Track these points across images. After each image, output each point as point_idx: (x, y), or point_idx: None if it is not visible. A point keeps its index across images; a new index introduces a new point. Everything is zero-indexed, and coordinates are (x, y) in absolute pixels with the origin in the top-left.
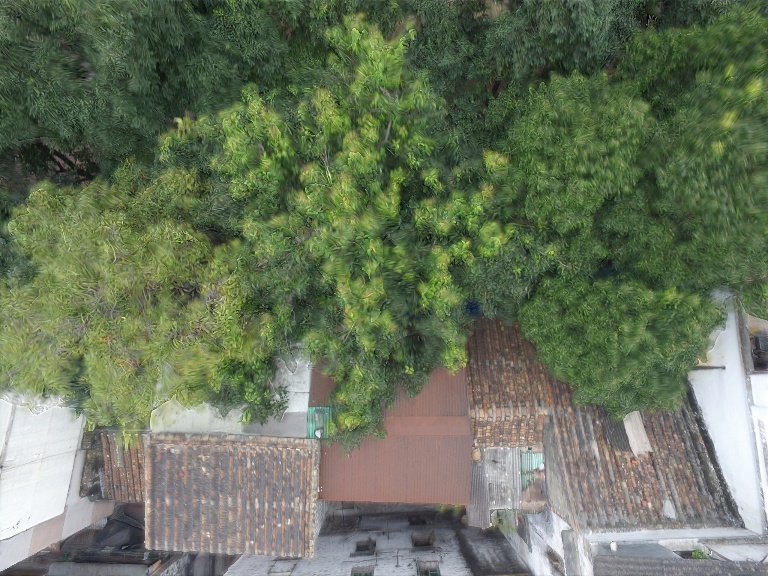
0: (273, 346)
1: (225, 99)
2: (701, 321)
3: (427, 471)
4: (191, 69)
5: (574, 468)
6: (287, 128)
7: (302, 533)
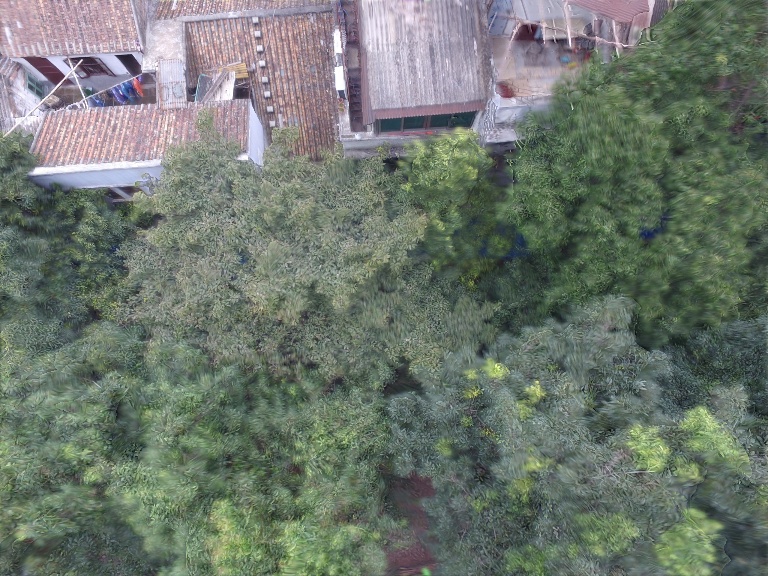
0: None
1: None
2: None
3: None
4: None
5: None
6: None
7: None
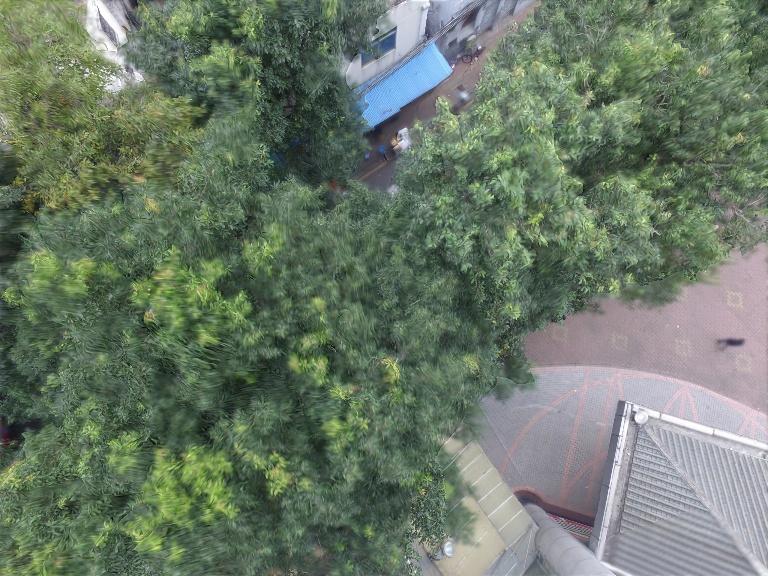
0: None
1: None
2: None
3: None
4: None
5: None
6: None
7: None
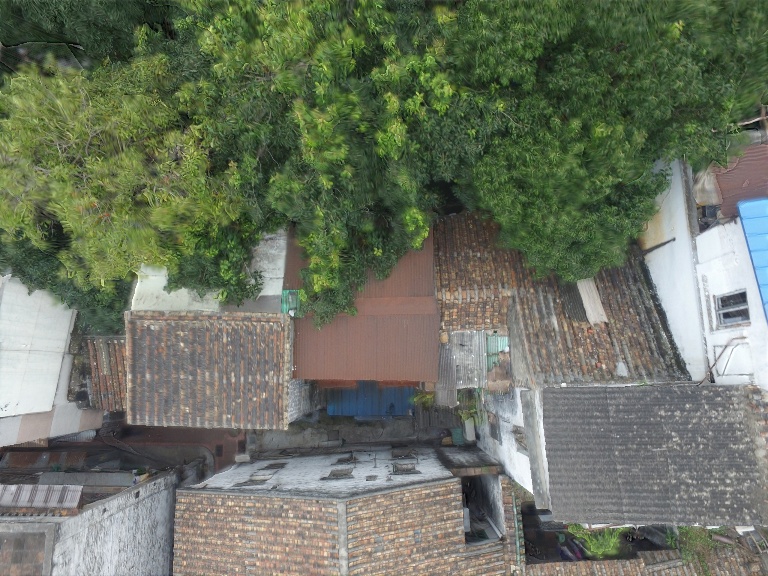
0: (240, 193)
1: None
2: (633, 146)
3: (396, 349)
4: None
5: (534, 338)
6: None
7: (276, 406)
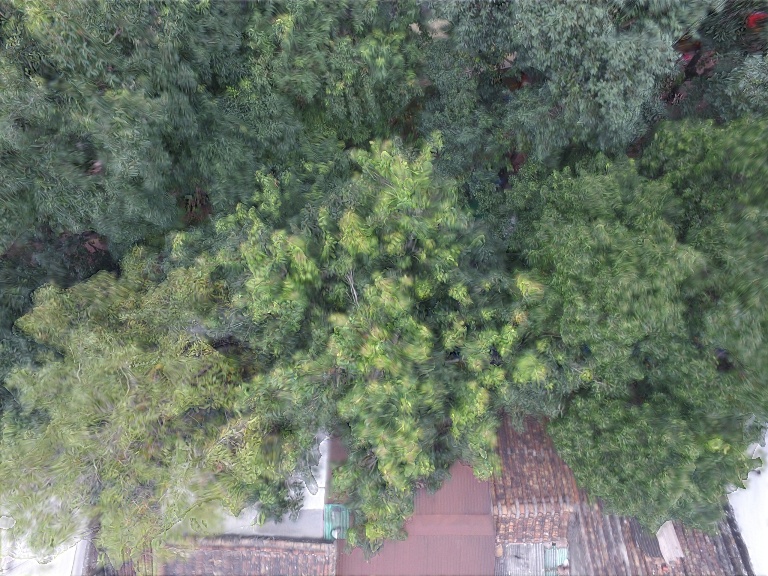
0: None
1: (239, 181)
2: (752, 467)
3: (448, 572)
4: (204, 152)
5: (603, 575)
6: (307, 228)
7: None
